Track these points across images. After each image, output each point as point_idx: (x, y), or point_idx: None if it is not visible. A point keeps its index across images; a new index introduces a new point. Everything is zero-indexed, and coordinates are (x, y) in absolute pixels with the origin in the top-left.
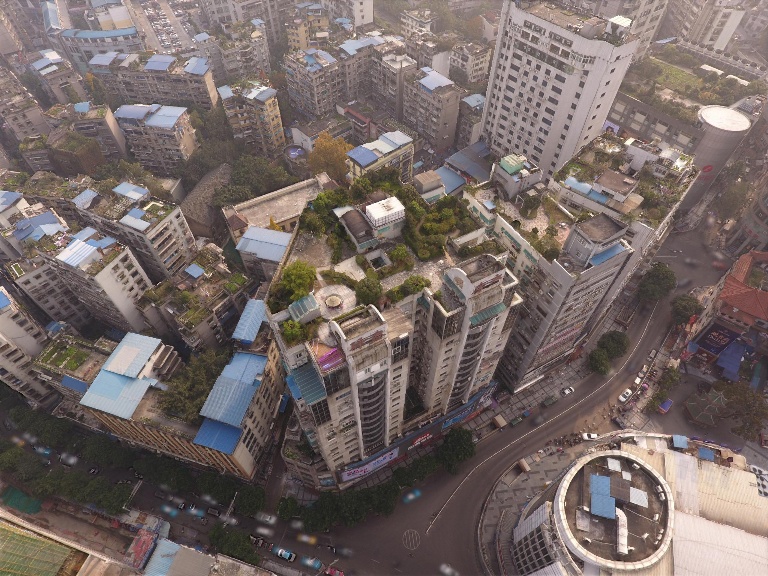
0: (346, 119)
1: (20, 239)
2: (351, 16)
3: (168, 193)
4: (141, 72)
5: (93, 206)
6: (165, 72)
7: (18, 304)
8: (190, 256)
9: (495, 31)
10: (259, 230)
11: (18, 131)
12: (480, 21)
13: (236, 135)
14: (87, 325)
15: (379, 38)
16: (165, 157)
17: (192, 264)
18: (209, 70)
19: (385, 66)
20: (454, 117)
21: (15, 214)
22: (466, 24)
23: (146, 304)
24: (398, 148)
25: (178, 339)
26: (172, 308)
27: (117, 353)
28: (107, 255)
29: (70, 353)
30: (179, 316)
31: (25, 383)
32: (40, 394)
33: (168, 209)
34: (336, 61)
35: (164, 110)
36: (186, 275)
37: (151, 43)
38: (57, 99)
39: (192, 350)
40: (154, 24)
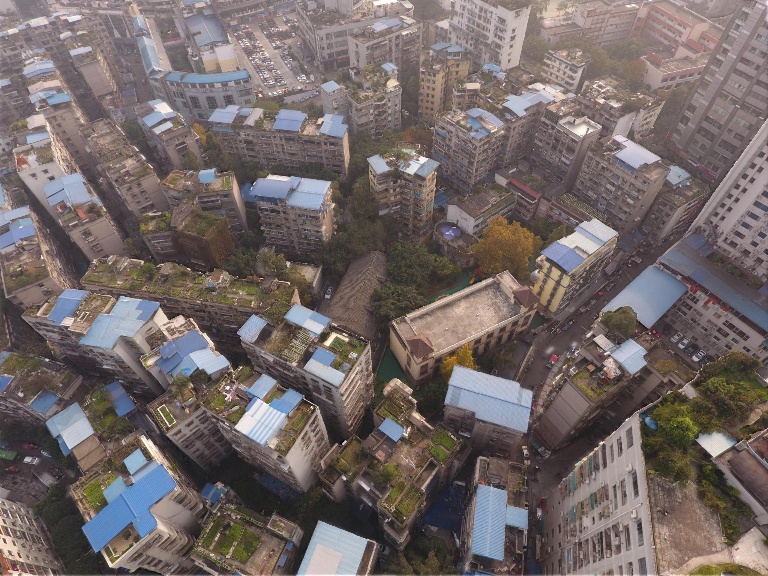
0: (508, 191)
1: (166, 372)
2: (496, 60)
3: (310, 286)
4: (268, 131)
5: (262, 339)
6: (296, 132)
7: (168, 461)
8: (365, 390)
9: (664, 78)
10: (468, 373)
11: (131, 201)
12: (642, 65)
13: (381, 211)
14: (226, 458)
15: (546, 93)
16: (300, 237)
17: (386, 418)
18: (346, 130)
19: (562, 131)
20: (652, 197)
21: (151, 329)
22: (622, 67)
23: (334, 476)
24: (602, 245)
25: (354, 502)
26: (368, 483)
27: (311, 557)
28: (293, 418)
29: (236, 534)
30: (381, 499)
31: (176, 566)
32: (187, 569)
33: (357, 346)
34: (504, 125)
35: (305, 185)
36: (382, 436)
37: (252, 82)
38: (169, 159)
39: (390, 536)
40: (252, 58)
